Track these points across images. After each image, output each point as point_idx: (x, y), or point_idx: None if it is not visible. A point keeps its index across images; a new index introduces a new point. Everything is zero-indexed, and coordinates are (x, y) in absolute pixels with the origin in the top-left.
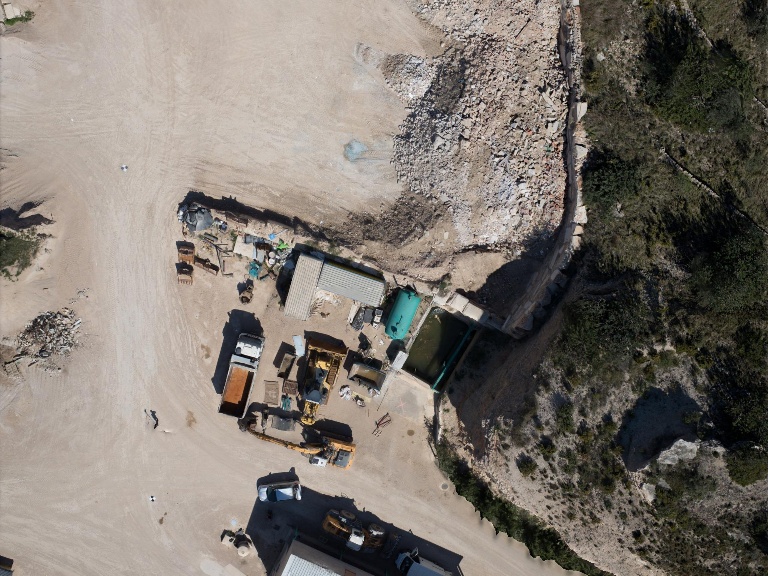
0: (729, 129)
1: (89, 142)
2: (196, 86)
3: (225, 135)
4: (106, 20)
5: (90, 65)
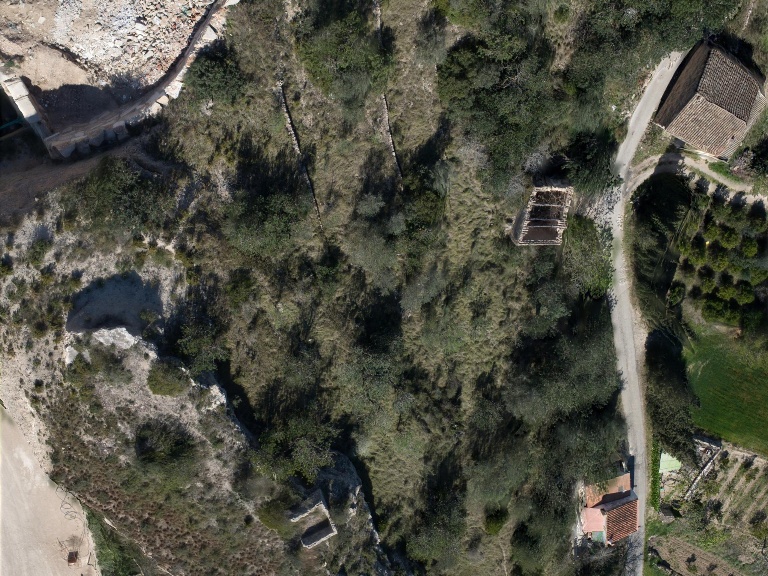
0: (345, 105)
1: None
2: None
3: None
4: None
5: None
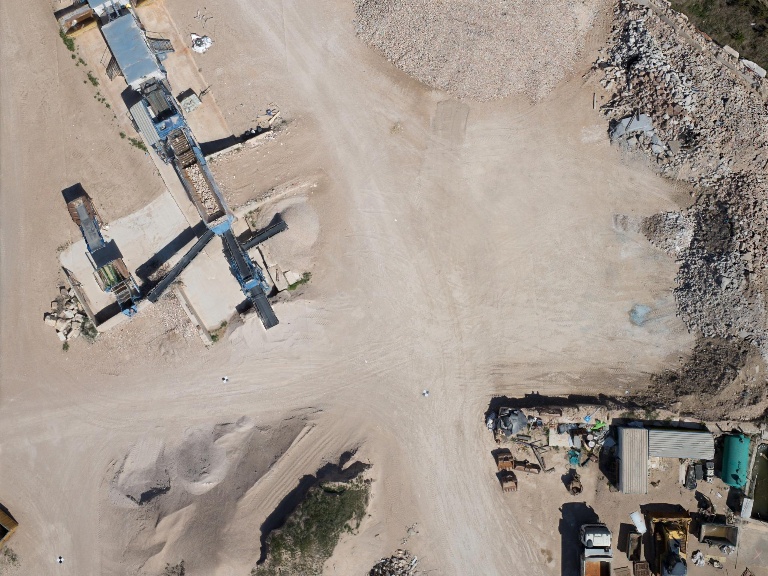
0: None
1: (386, 378)
2: (474, 297)
3: (513, 335)
4: (377, 261)
5: (372, 306)
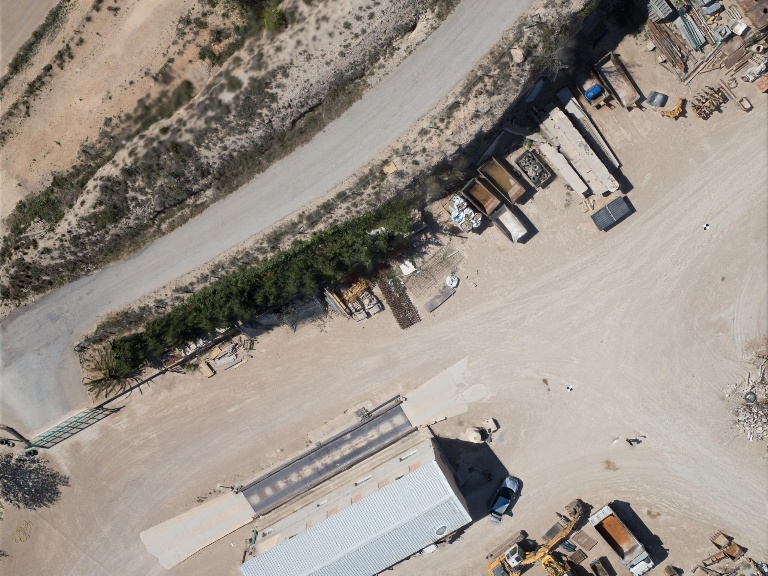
0: None
1: None
2: None
3: None
4: None
5: None
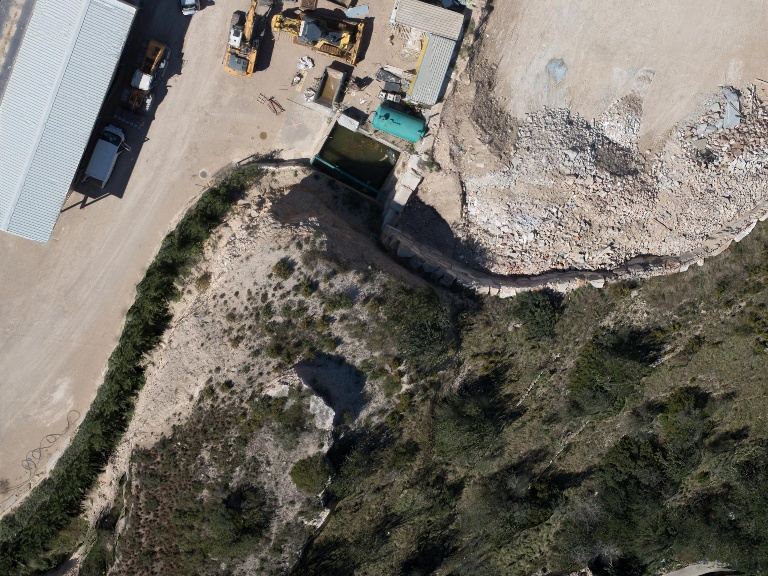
0: (570, 406)
1: None
2: None
3: None
4: None
5: None
